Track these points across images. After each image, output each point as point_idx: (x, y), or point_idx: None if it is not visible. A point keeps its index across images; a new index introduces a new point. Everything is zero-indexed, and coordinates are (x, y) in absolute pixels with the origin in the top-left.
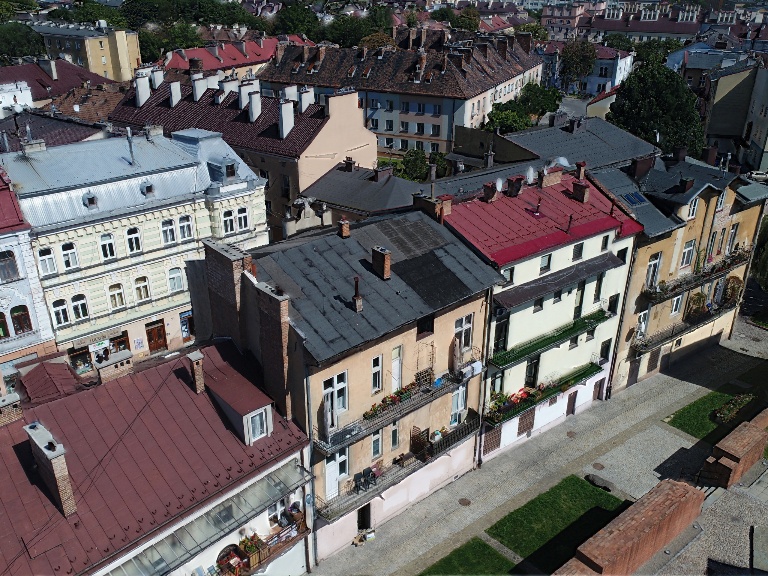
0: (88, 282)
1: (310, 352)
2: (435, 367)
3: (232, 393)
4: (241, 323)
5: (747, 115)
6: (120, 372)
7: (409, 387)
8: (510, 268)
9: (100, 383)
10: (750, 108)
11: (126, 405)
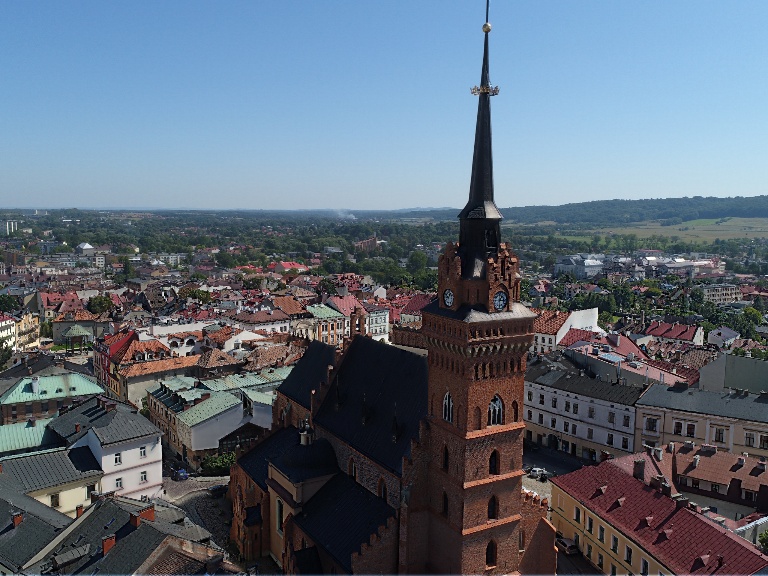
0: None
1: None
2: None
3: None
4: None
5: (38, 308)
6: None
7: None
8: None
9: None
10: (38, 306)
11: None
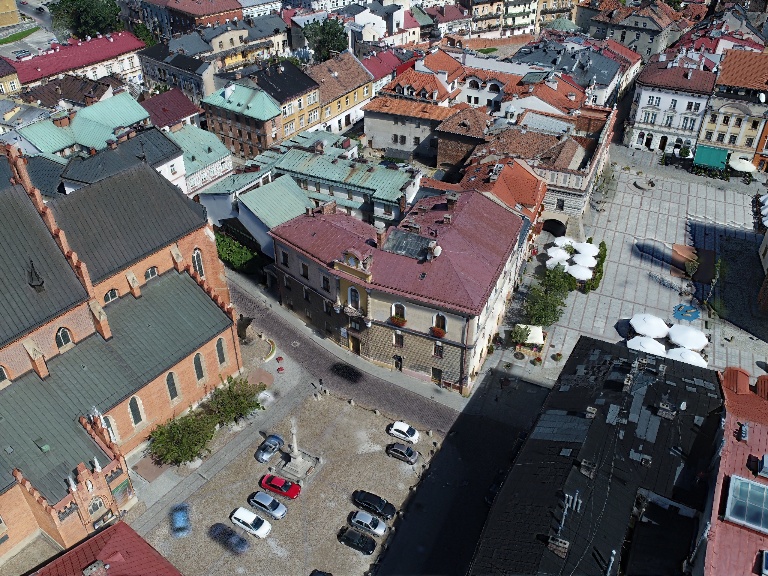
0: (430, 3)
1: (474, 2)
2: (493, 12)
3: (463, 8)
4: (465, 0)
5: None
6: (448, 4)
7: (488, 14)
8: None
9: (446, 5)
10: None
11: (449, 8)
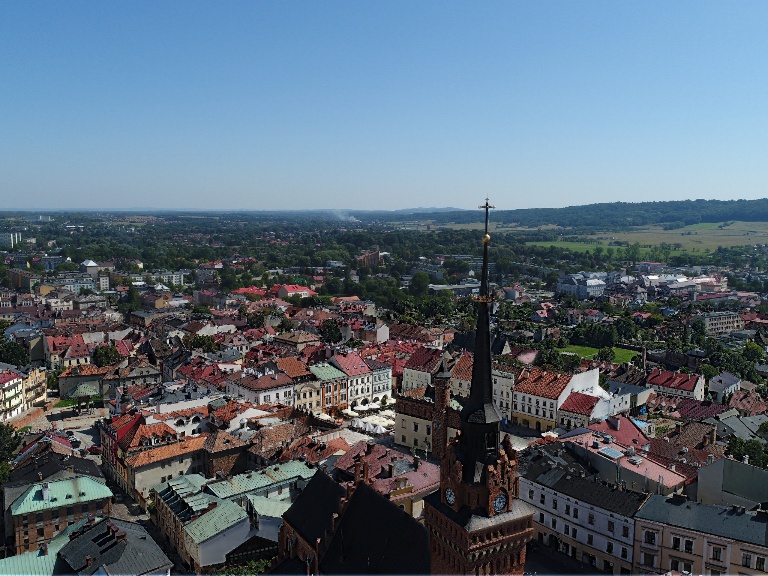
0: None
1: None
2: None
3: None
4: None
5: (44, 352)
6: None
7: None
8: (4, 384)
9: None
10: (44, 349)
11: None
